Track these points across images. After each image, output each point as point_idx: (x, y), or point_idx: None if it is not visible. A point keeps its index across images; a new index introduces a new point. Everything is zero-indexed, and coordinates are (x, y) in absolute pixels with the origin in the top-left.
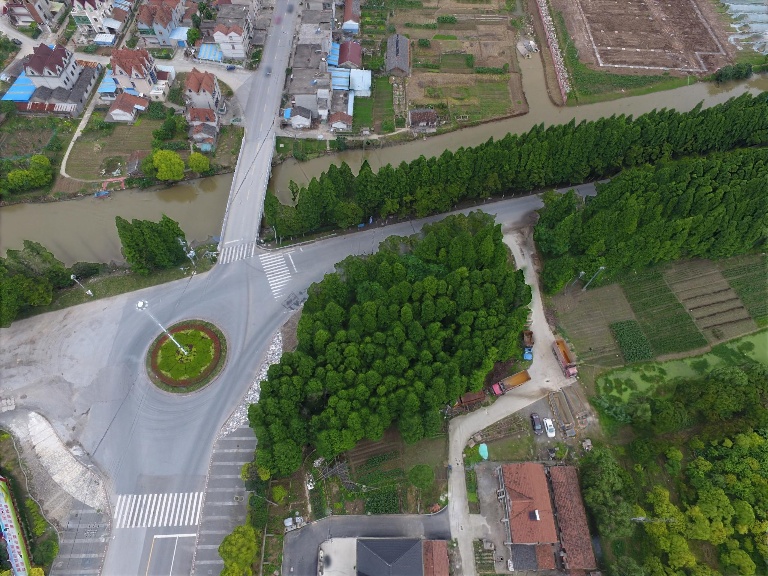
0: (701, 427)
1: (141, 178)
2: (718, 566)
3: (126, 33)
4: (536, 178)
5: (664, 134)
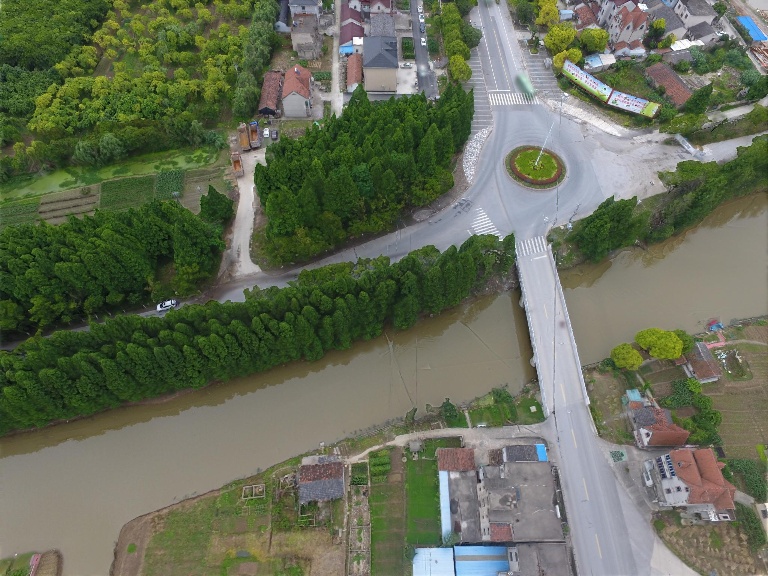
0: None
1: None
2: None
3: None
4: None
5: None
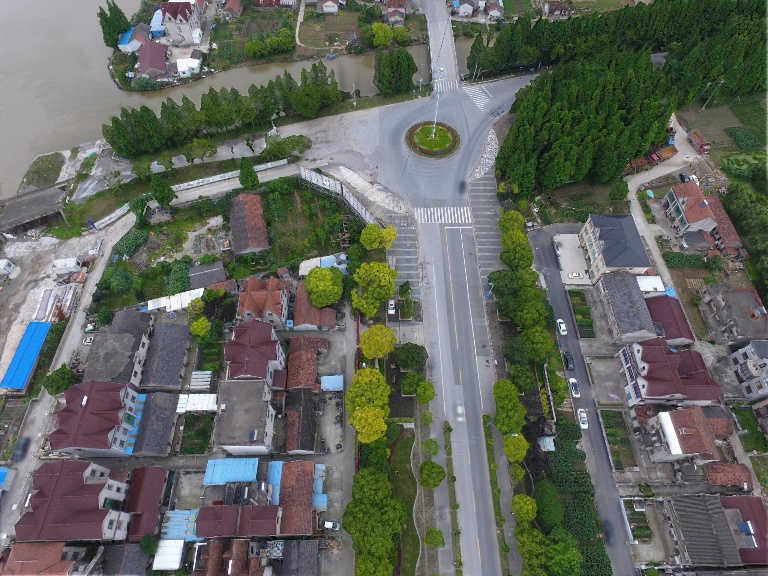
0: None
1: (357, 46)
2: None
3: None
4: (661, 35)
5: (755, 4)
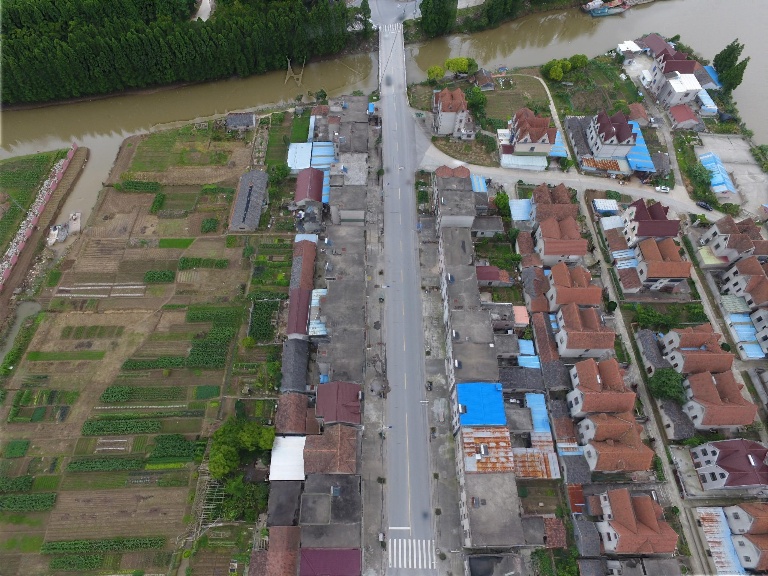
0: None
1: None
2: None
3: (594, 227)
4: None
5: None
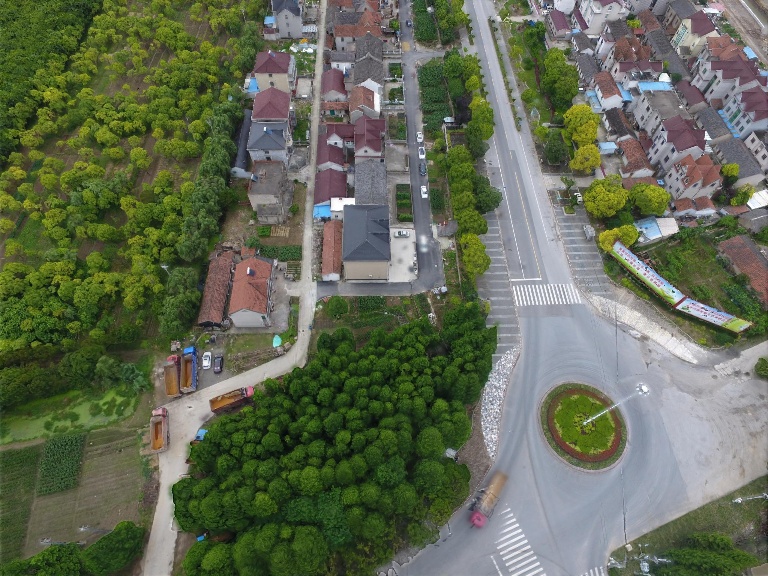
0: (51, 360)
1: None
2: (114, 265)
3: None
4: None
5: None
